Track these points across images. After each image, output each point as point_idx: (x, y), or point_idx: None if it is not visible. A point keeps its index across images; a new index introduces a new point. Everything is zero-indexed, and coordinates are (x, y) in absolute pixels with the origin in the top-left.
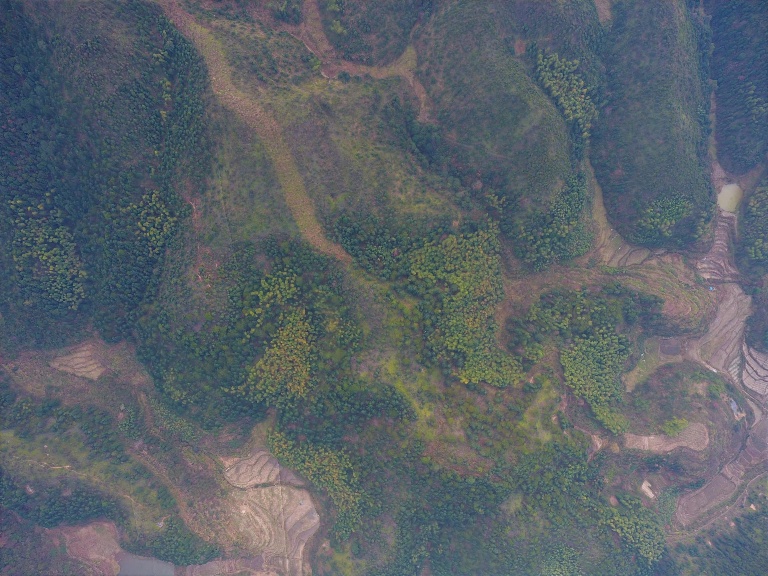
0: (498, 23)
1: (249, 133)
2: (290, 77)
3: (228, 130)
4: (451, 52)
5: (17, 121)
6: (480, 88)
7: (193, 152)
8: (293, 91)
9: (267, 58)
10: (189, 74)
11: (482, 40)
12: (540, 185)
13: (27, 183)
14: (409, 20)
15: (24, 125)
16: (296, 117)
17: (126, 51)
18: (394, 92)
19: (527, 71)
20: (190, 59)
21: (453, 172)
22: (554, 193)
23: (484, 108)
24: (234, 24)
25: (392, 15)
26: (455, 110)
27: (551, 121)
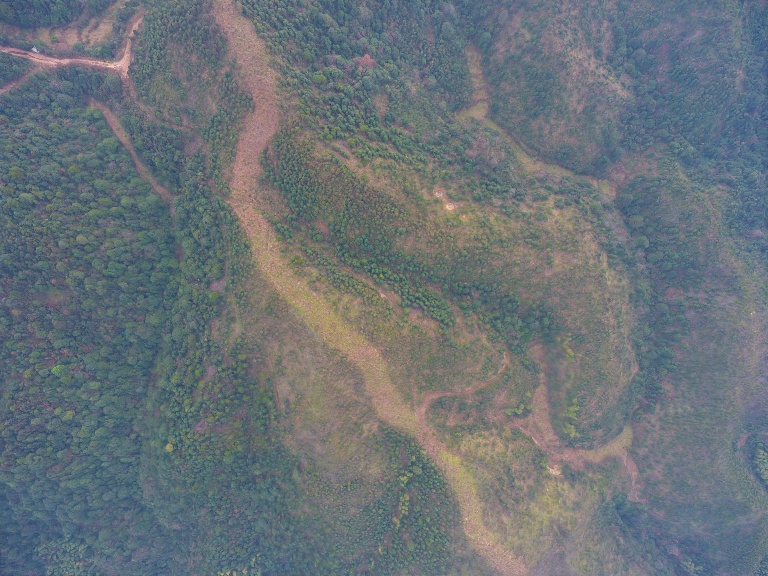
0: (731, 434)
1: (495, 574)
2: (525, 488)
3: (472, 565)
4: (679, 455)
5: (242, 507)
6: (705, 492)
7: (427, 570)
8: (534, 517)
9: (508, 476)
10: (432, 496)
11: (717, 455)
12: (744, 567)
13: (238, 554)
14: (632, 407)
15: (248, 510)
16: (540, 553)
17: (376, 479)
18: (616, 486)
19: (746, 465)
20: (439, 489)
21: (650, 535)
22: (753, 569)
23: (703, 504)
24: (479, 443)
25: (620, 410)
26: (671, 500)
27: (766, 515)
